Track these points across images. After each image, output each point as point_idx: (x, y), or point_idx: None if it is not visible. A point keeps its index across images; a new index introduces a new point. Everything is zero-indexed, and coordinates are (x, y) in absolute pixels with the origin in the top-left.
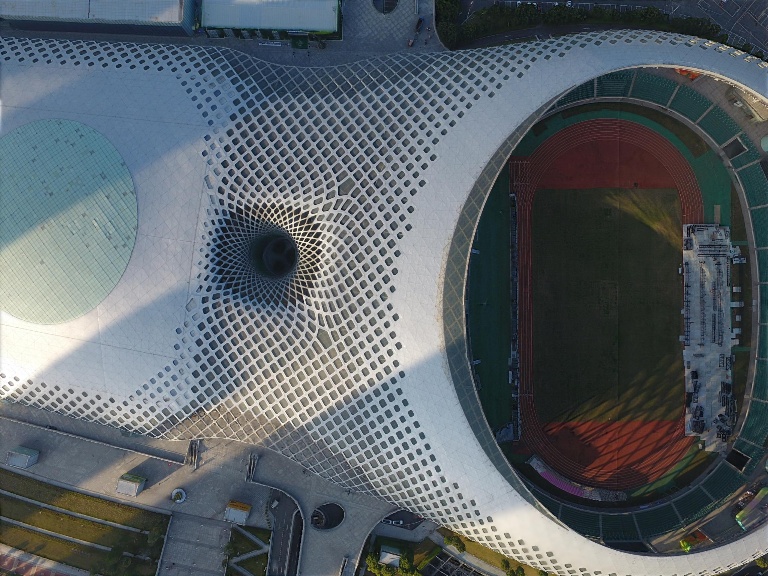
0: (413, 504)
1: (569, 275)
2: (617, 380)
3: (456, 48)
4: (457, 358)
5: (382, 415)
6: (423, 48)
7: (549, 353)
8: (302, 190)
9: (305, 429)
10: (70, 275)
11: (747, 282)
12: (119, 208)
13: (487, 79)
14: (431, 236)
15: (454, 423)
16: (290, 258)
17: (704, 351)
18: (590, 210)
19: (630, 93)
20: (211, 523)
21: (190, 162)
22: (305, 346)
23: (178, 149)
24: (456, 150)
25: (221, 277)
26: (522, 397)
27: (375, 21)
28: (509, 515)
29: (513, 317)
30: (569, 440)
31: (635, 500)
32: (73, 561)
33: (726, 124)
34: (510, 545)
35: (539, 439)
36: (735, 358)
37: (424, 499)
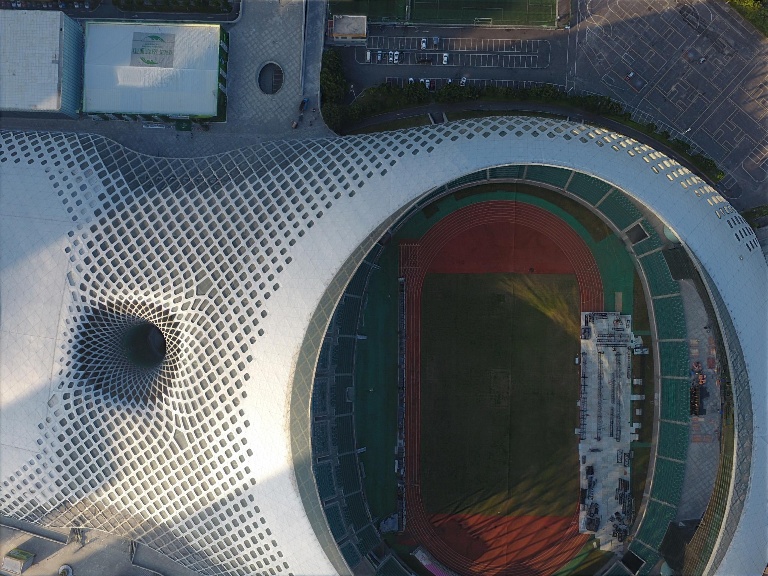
0: None
1: (459, 363)
2: (508, 473)
3: (344, 128)
4: (303, 470)
5: (237, 519)
6: (308, 130)
7: (437, 443)
8: (162, 288)
9: None
10: None
11: (649, 374)
12: None
13: (351, 175)
14: (281, 343)
15: (303, 534)
16: None
17: (601, 445)
18: (483, 295)
19: (525, 175)
20: None
21: (53, 259)
22: (163, 446)
23: (42, 245)
24: (311, 253)
25: (83, 373)
26: (408, 487)
27: (259, 102)
28: None
29: (400, 405)
30: (456, 533)
31: None
32: None
33: (626, 209)
34: None
35: (425, 530)
36: (634, 454)
37: None
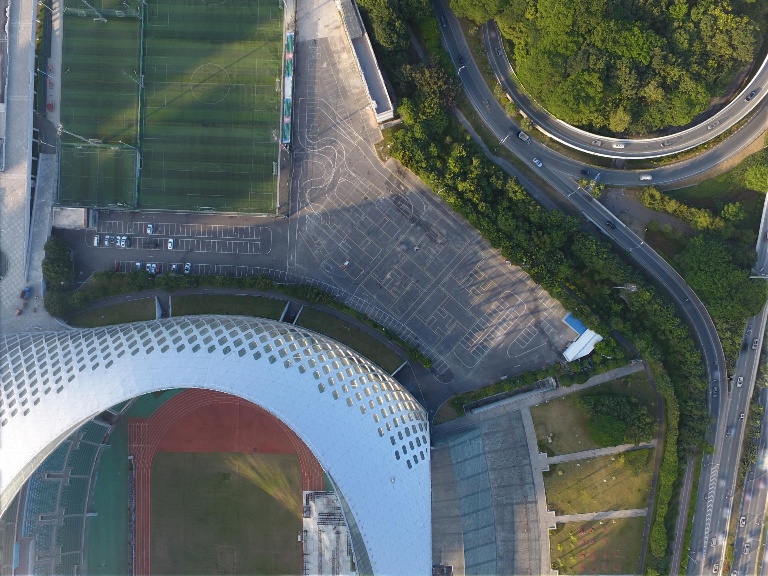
0: None
1: (187, 539)
2: None
3: (70, 312)
4: None
5: None
6: (32, 316)
7: None
8: None
9: None
10: None
11: None
12: None
13: (31, 390)
14: None
15: None
16: None
17: None
18: (209, 474)
19: None
20: None
21: None
22: None
23: None
24: None
25: None
26: None
27: None
28: None
29: None
30: None
31: None
32: None
33: None
34: None
35: None
36: None
37: None
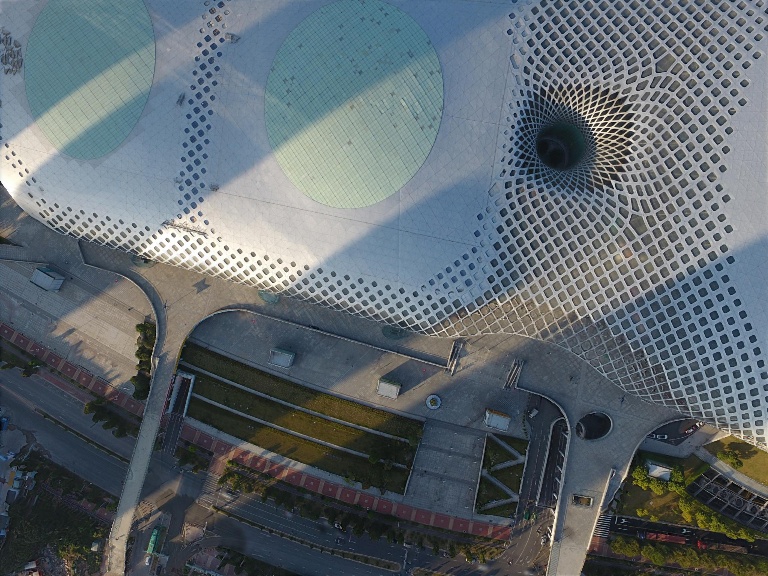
0: (713, 407)
1: None
2: None
3: None
4: None
5: (700, 305)
6: None
7: None
8: (614, 69)
9: (605, 323)
10: (376, 156)
11: None
12: (426, 87)
13: None
14: None
15: None
16: (556, 158)
17: None
18: None
19: None
20: (465, 431)
21: (495, 41)
22: (615, 233)
23: (482, 28)
24: None
25: (523, 162)
26: None
27: None
28: None
29: None
30: None
31: None
32: (324, 465)
33: None
34: None
35: None
36: None
37: (731, 400)
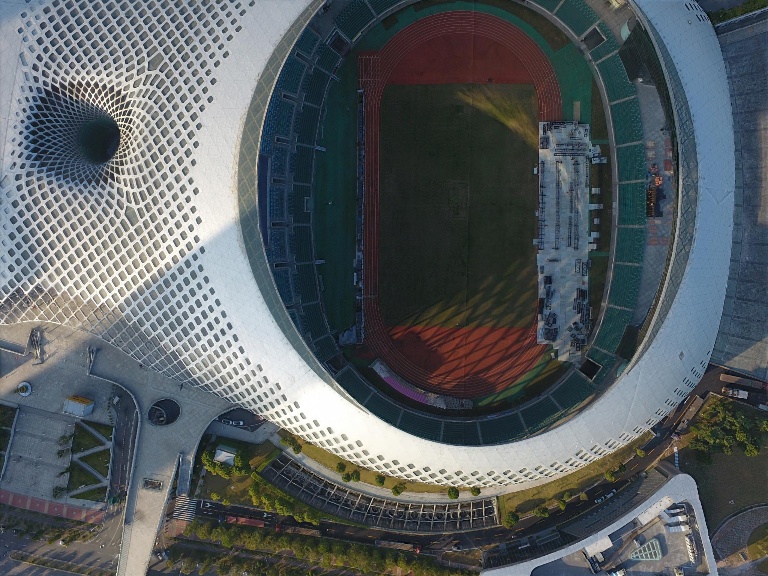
0: (230, 392)
1: (418, 174)
2: (466, 284)
3: None
4: (250, 230)
5: (187, 294)
6: None
7: (396, 255)
8: (114, 67)
9: (119, 311)
10: None
11: (607, 183)
12: None
13: None
14: (230, 107)
15: (251, 299)
16: None
17: (559, 255)
18: (441, 107)
19: None
20: (56, 418)
21: (6, 39)
22: (114, 224)
23: None
24: (260, 20)
25: (36, 155)
26: (367, 299)
27: None
28: (312, 399)
29: (358, 217)
30: (415, 345)
31: (482, 409)
32: None
33: (584, 13)
34: (323, 435)
35: (384, 343)
36: (591, 263)
37: (237, 385)
